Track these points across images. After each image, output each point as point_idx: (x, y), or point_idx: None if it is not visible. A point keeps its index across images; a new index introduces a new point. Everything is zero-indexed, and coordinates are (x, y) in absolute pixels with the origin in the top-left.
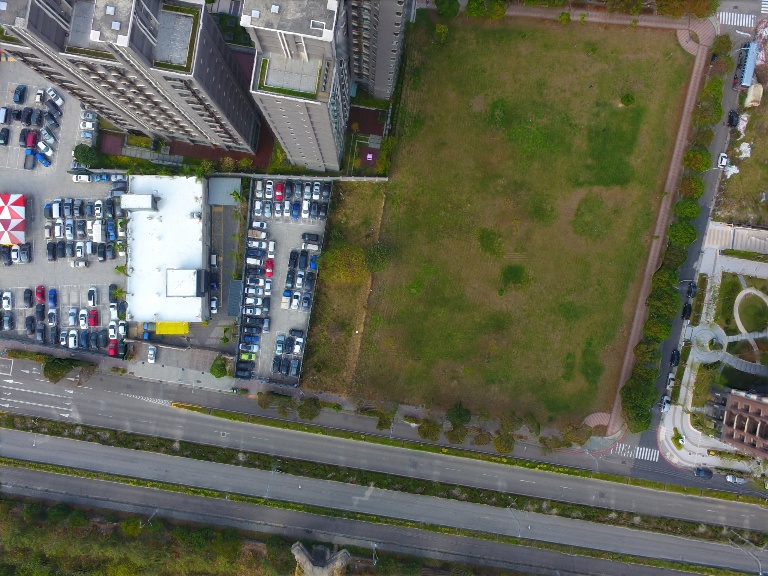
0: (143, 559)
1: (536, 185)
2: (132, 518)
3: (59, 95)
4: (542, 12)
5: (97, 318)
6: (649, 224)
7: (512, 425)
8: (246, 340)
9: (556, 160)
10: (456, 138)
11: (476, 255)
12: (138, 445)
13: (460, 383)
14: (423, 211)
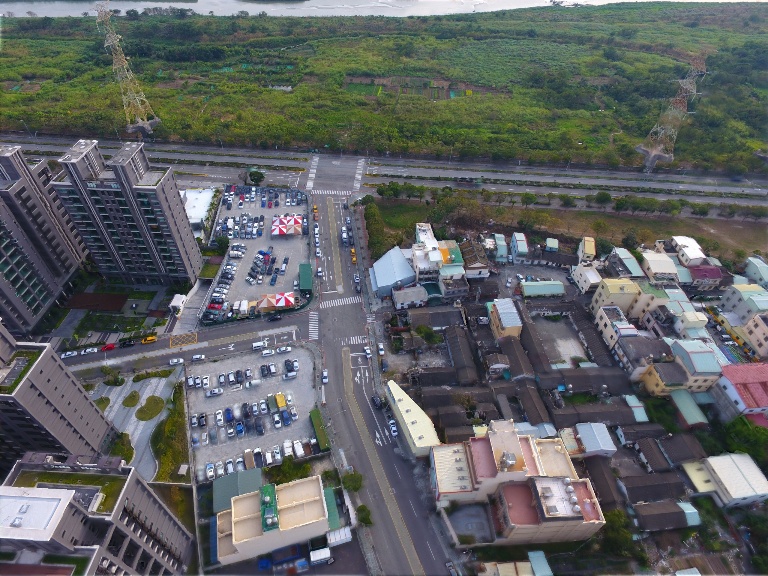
0: None
1: None
2: (230, 142)
3: (248, 282)
4: None
5: None
6: None
7: None
8: None
9: None
10: None
11: None
12: None
13: None
14: None
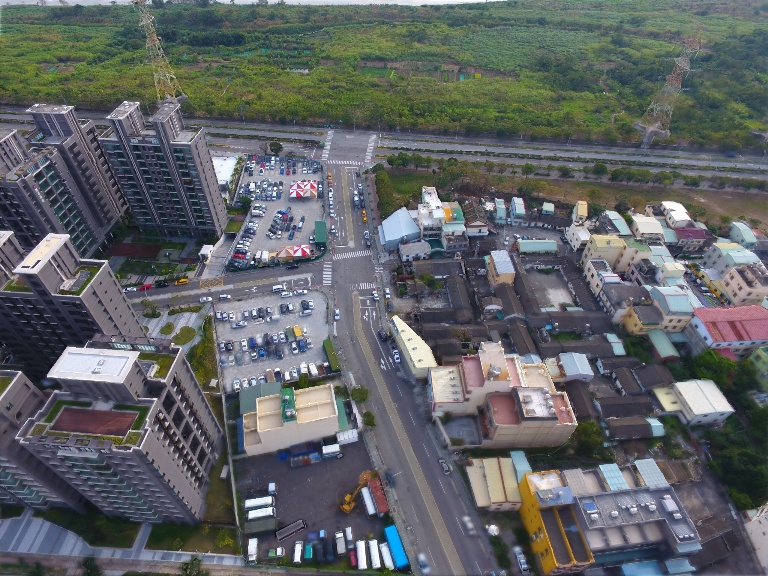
0: None
1: None
2: (251, 117)
3: (269, 237)
4: None
5: None
6: None
7: None
8: None
9: None
10: None
11: None
12: None
13: None
14: None
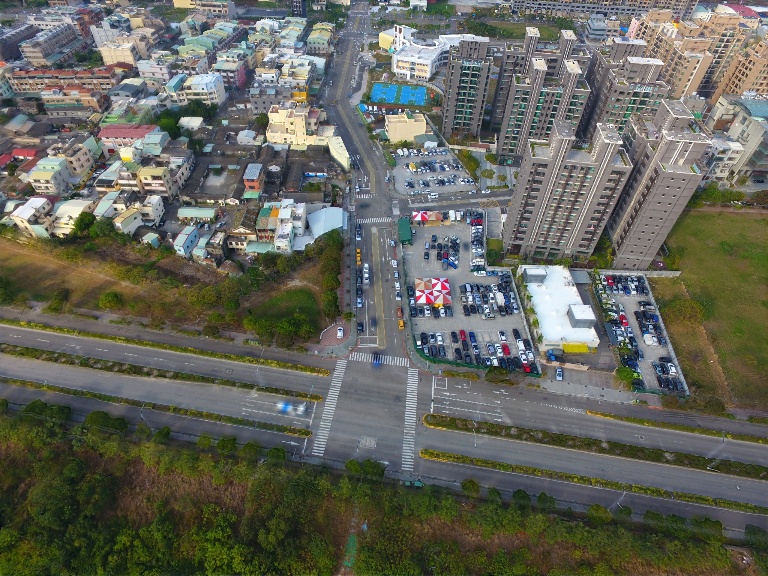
0: (632, 539)
1: None
2: (597, 504)
3: None
4: (719, 209)
5: None
6: None
7: None
8: (630, 364)
9: None
10: (708, 257)
11: None
12: (570, 445)
13: None
14: (713, 291)
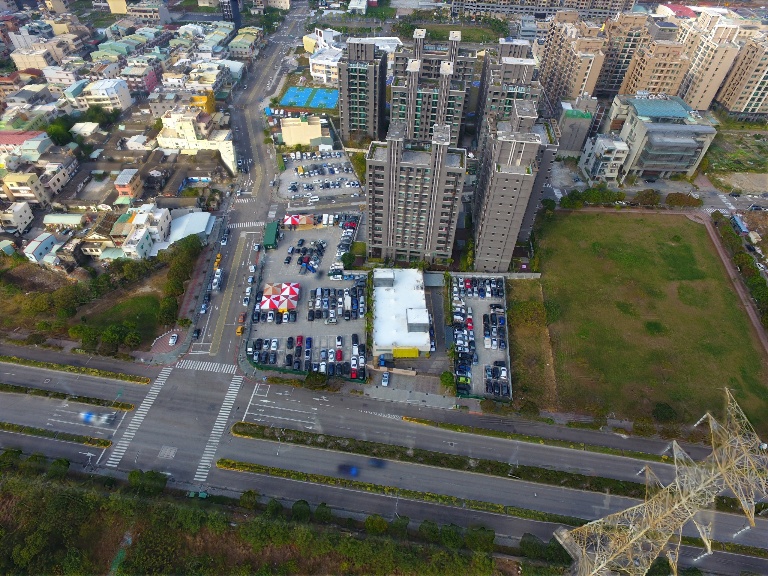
0: (395, 551)
1: (642, 279)
2: (377, 514)
3: None
4: (602, 210)
5: (341, 355)
6: (735, 299)
7: (717, 418)
8: (461, 368)
9: (648, 268)
10: (576, 259)
11: (620, 316)
12: (374, 452)
13: (650, 401)
14: (570, 293)
